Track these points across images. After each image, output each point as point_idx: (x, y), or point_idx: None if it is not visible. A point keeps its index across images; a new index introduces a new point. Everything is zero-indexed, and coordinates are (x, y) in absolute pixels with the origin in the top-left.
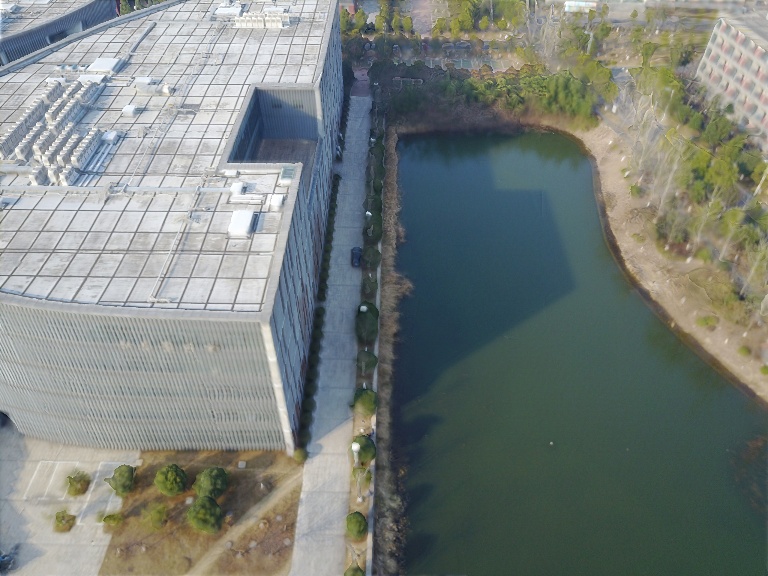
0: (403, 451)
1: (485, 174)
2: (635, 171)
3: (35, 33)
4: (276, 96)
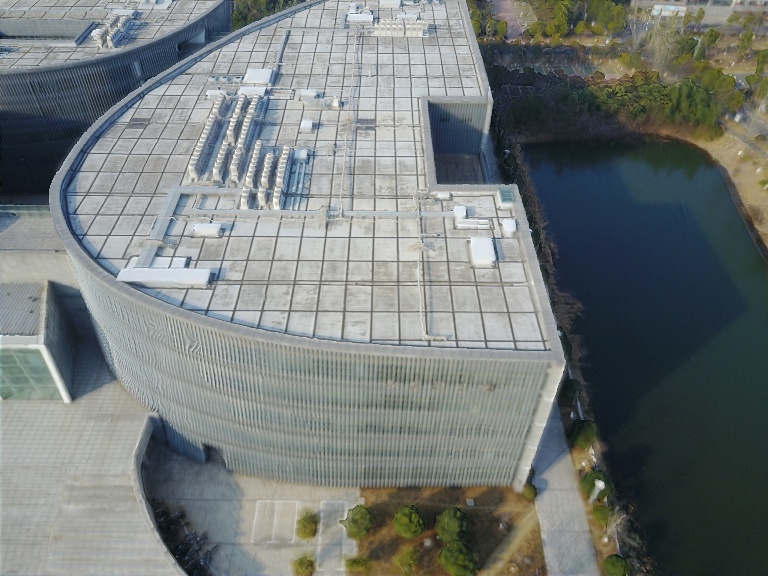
0: (626, 484)
1: (618, 186)
2: None
3: (167, 41)
4: (446, 110)
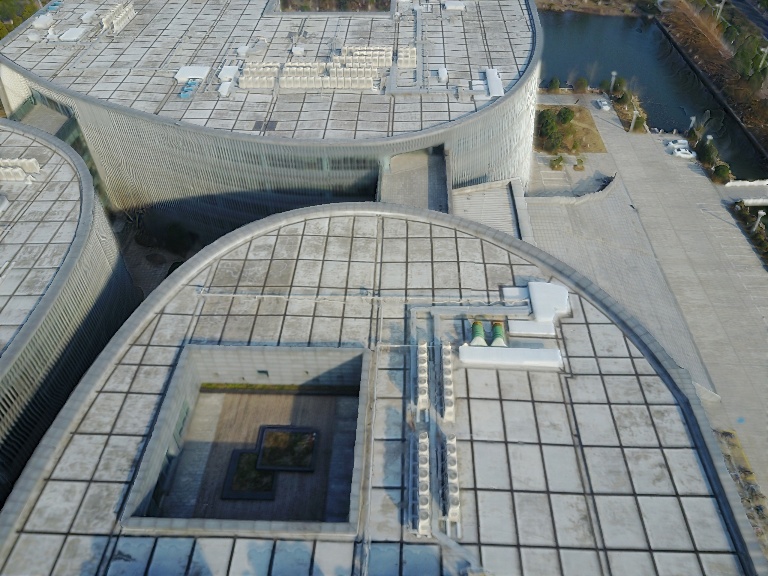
0: None
1: None
2: (281, 8)
3: None
4: None
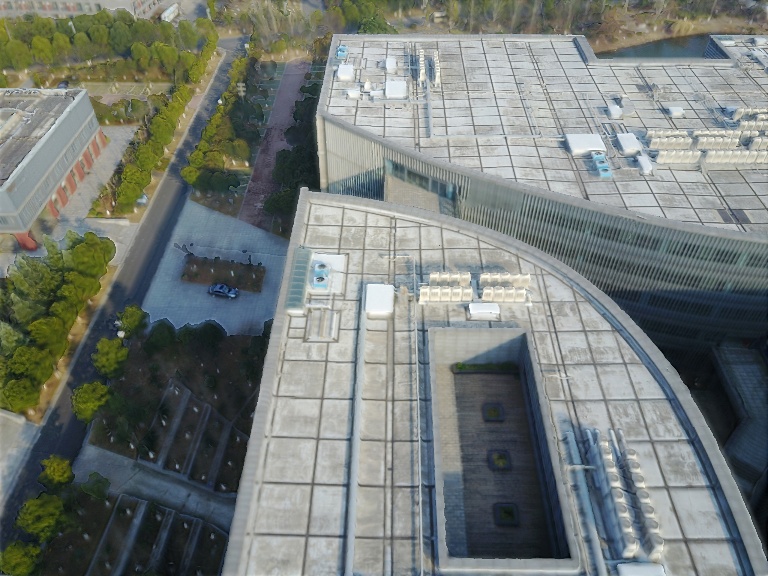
0: None
1: None
2: None
3: None
4: None
